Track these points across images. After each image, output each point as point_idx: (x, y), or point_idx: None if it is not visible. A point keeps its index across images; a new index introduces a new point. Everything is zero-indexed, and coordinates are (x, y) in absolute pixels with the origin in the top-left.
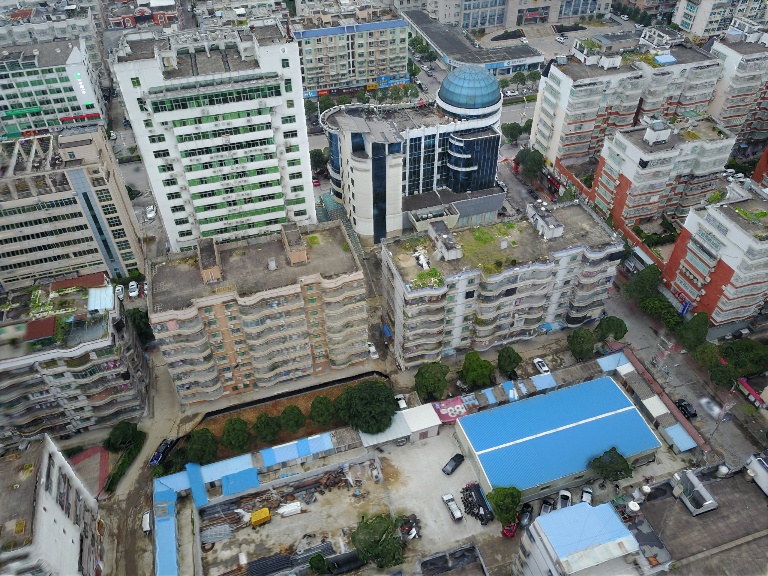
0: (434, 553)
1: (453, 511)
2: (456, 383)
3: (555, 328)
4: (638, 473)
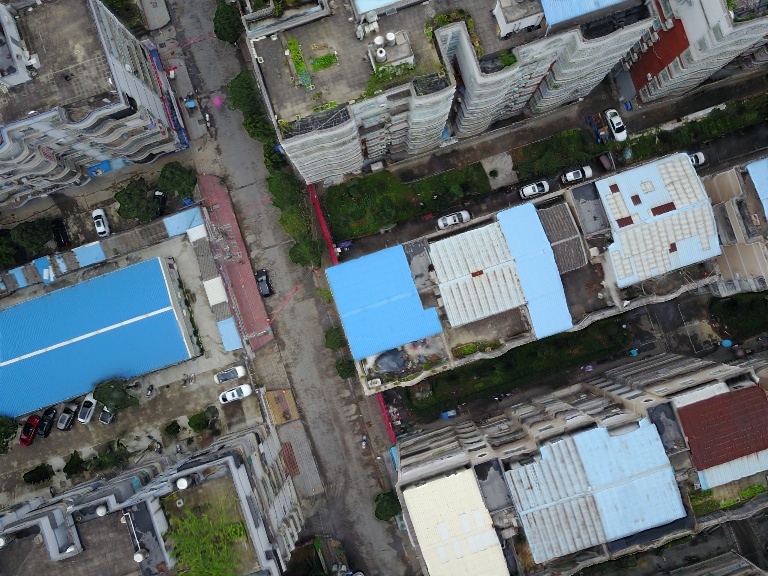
0: None
1: None
2: None
3: (117, 167)
4: (180, 370)
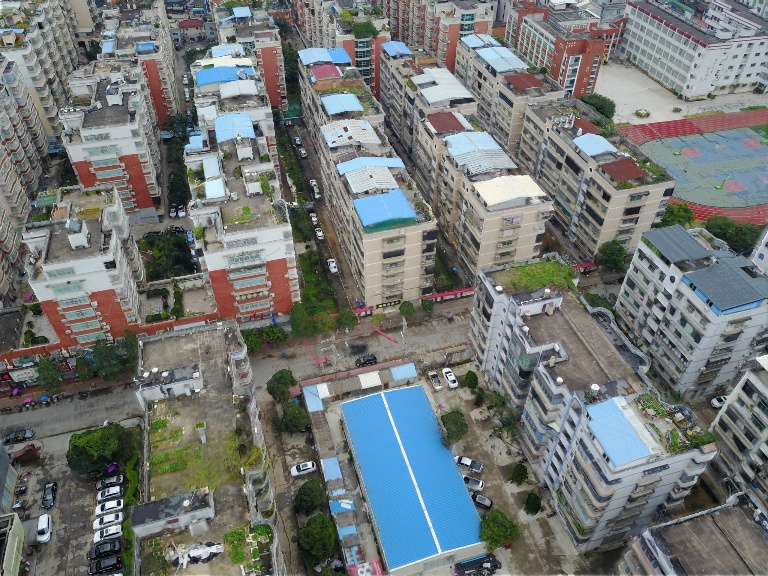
0: (672, 570)
1: None
2: (318, 572)
3: None
4: None
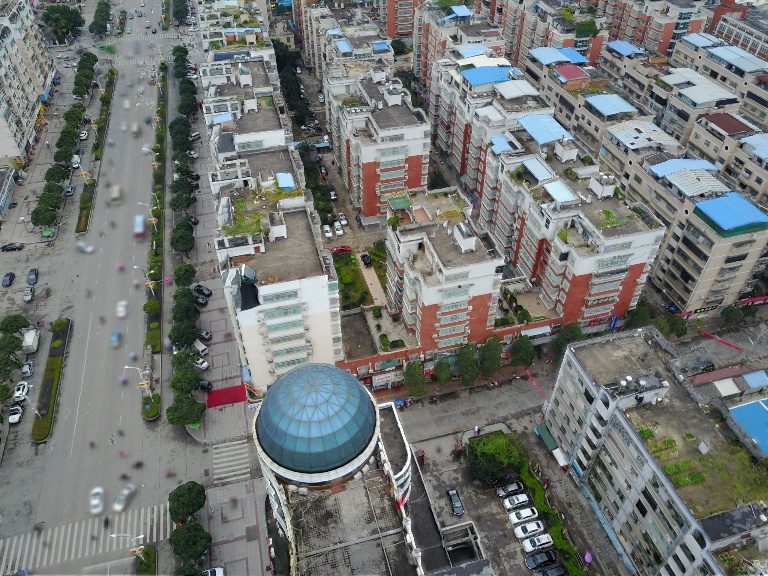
0: None
1: None
2: None
3: None
4: None
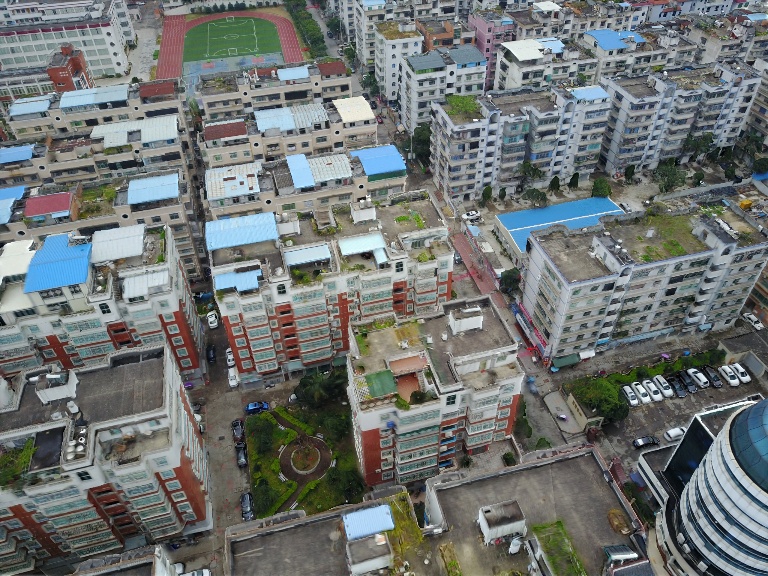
0: None
1: (627, 205)
2: None
3: None
4: None
